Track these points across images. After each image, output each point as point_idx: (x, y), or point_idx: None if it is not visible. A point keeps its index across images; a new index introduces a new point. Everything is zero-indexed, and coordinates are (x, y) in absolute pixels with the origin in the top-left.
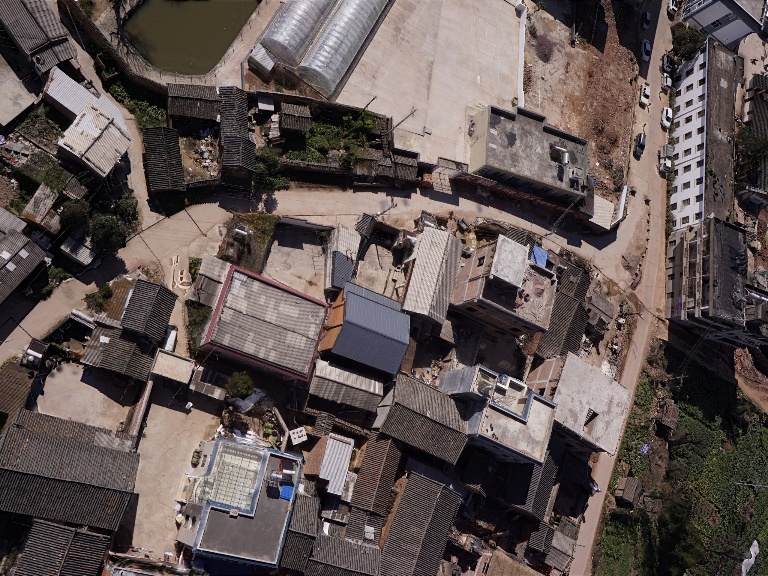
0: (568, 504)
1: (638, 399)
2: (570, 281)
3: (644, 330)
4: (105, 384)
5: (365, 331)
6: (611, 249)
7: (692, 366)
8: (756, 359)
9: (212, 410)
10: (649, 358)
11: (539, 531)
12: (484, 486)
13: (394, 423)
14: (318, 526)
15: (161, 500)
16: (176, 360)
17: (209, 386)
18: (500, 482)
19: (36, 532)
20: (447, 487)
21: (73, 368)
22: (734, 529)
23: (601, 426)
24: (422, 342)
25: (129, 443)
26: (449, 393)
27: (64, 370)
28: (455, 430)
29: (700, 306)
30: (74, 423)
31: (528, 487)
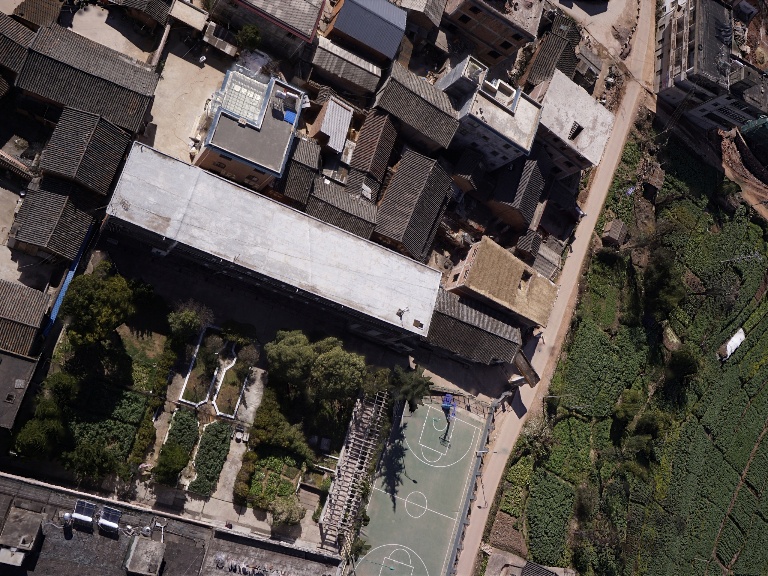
0: (556, 232)
1: (626, 156)
2: (560, 29)
3: (633, 97)
4: (127, 30)
5: (364, 11)
6: (602, 18)
7: (680, 147)
8: (744, 158)
9: (224, 69)
10: (637, 122)
11: (527, 236)
12: (475, 179)
13: (390, 99)
14: (319, 176)
15: (177, 134)
16: (191, 10)
17: (221, 41)
18: (490, 188)
19: (66, 116)
20: (439, 165)
21: (99, 11)
22: (719, 307)
23: (586, 139)
24: (419, 53)
25: (148, 70)
26: (443, 89)
27: (91, 11)
28: (447, 114)
29: (686, 69)
30: (99, 45)
31: (516, 189)
